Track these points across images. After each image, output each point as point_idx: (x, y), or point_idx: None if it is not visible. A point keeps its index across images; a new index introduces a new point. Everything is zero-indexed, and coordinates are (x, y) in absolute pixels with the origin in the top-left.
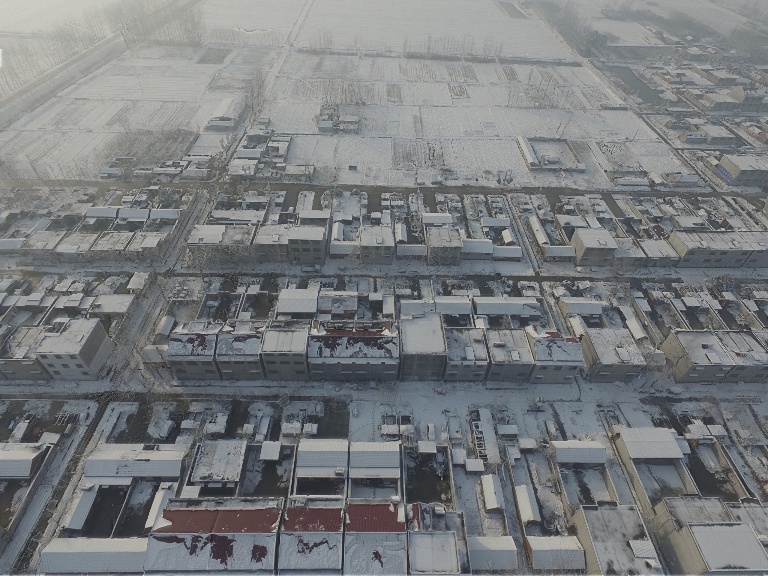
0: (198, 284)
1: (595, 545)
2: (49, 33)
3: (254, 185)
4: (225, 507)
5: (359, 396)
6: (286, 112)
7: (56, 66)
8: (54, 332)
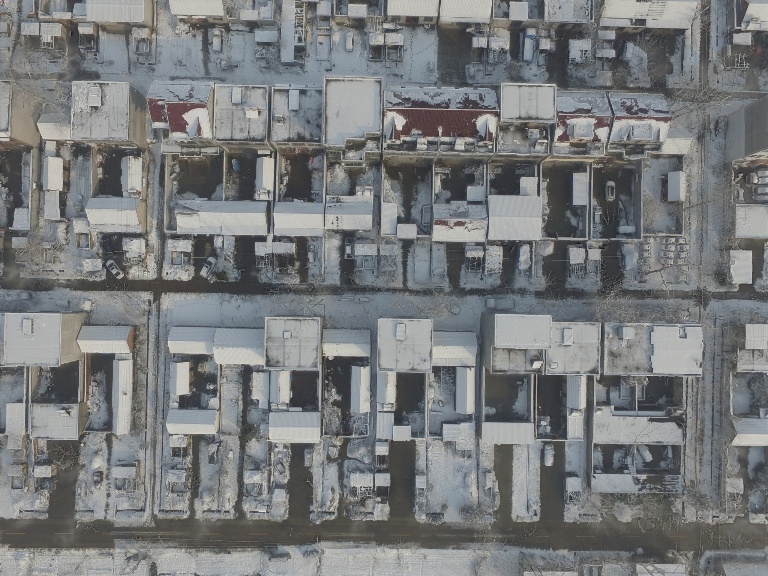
0: (656, 275)
1: None
2: None
3: (626, 543)
4: None
5: None
6: None
7: None
8: None
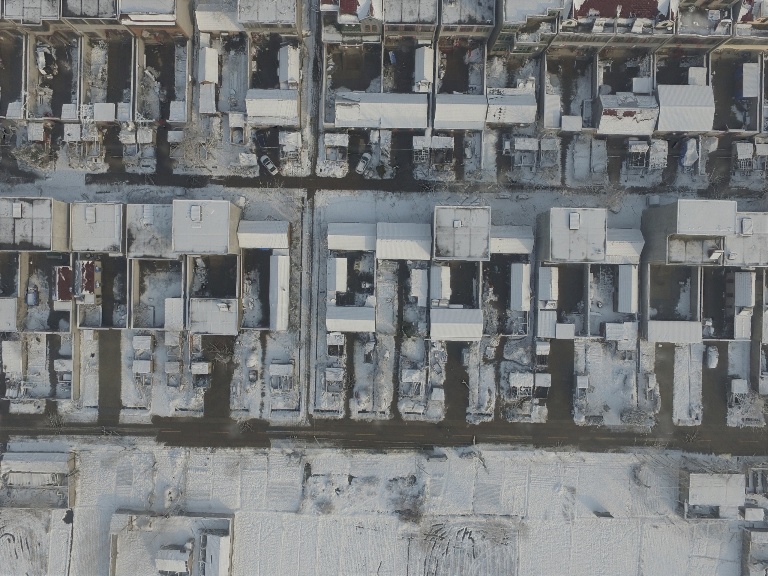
0: None
1: None
2: None
3: None
4: None
5: None
6: None
7: None
8: None
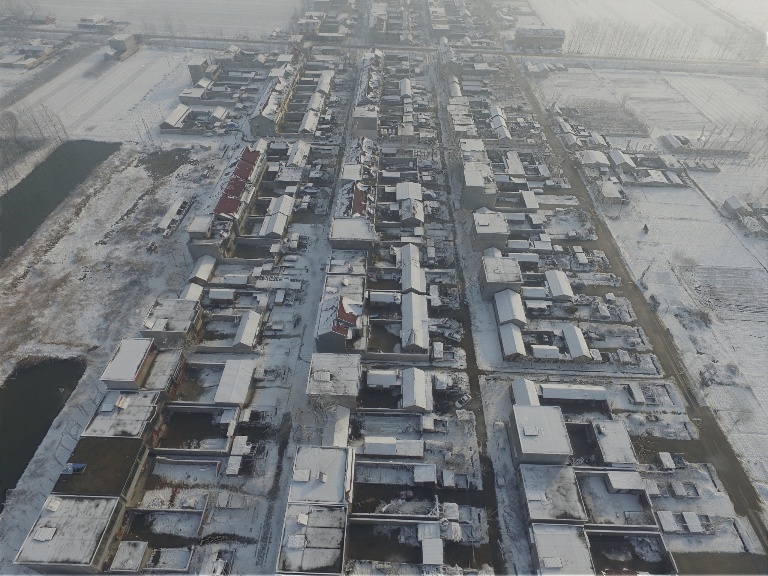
0: None
1: (174, 300)
2: (739, 32)
3: (573, 171)
4: (256, 168)
5: (327, 229)
6: (753, 181)
7: (714, 60)
8: (368, 108)
